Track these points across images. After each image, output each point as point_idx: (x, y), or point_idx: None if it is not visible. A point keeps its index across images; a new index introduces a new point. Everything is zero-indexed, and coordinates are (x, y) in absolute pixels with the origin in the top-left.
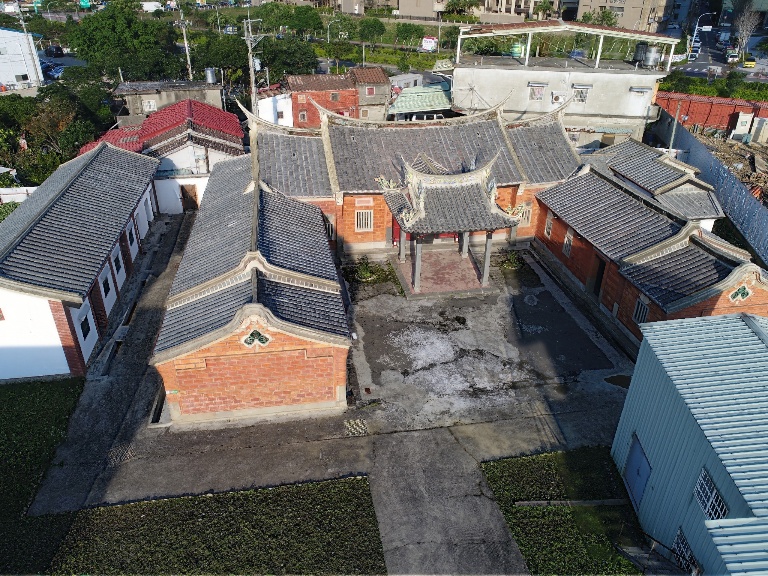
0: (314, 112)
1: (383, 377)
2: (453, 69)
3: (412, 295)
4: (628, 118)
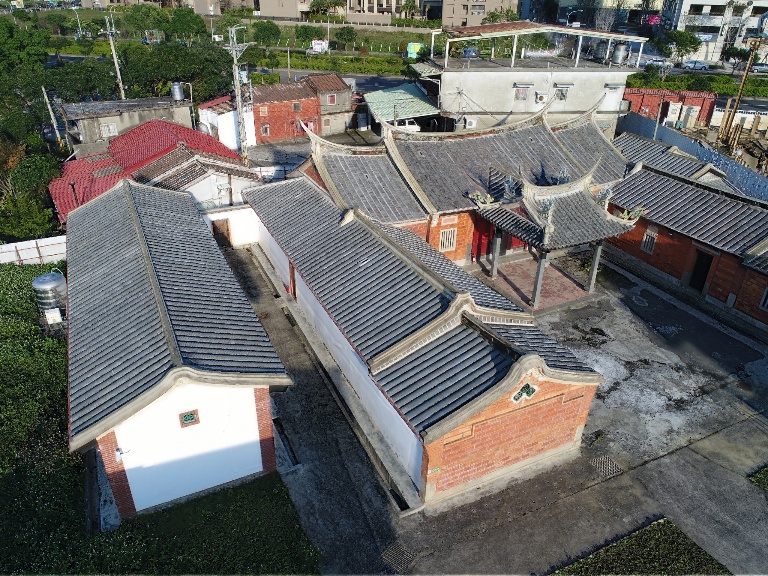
0: (276, 125)
1: None
2: (441, 73)
3: (534, 312)
4: (603, 113)
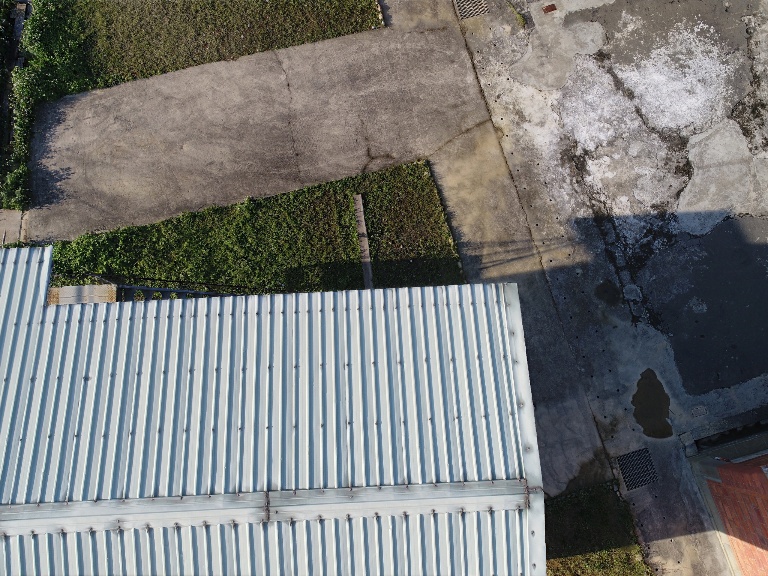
0: None
1: (585, 25)
2: None
3: None
4: None
